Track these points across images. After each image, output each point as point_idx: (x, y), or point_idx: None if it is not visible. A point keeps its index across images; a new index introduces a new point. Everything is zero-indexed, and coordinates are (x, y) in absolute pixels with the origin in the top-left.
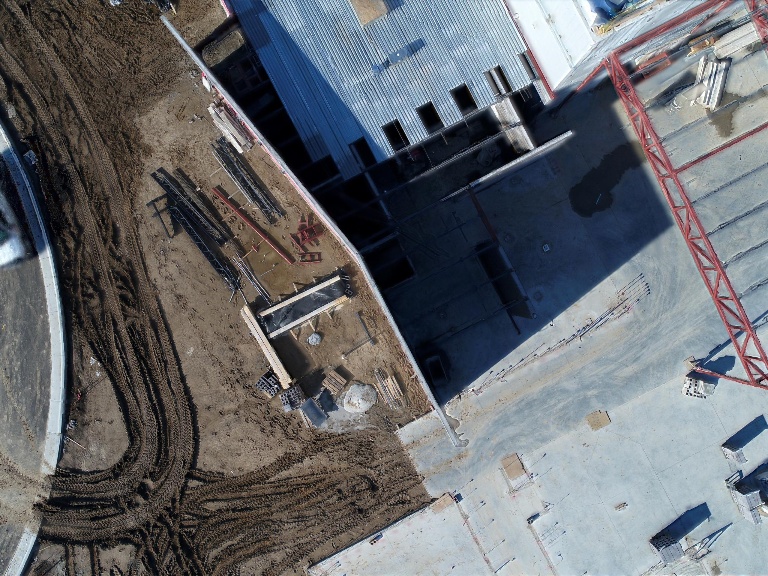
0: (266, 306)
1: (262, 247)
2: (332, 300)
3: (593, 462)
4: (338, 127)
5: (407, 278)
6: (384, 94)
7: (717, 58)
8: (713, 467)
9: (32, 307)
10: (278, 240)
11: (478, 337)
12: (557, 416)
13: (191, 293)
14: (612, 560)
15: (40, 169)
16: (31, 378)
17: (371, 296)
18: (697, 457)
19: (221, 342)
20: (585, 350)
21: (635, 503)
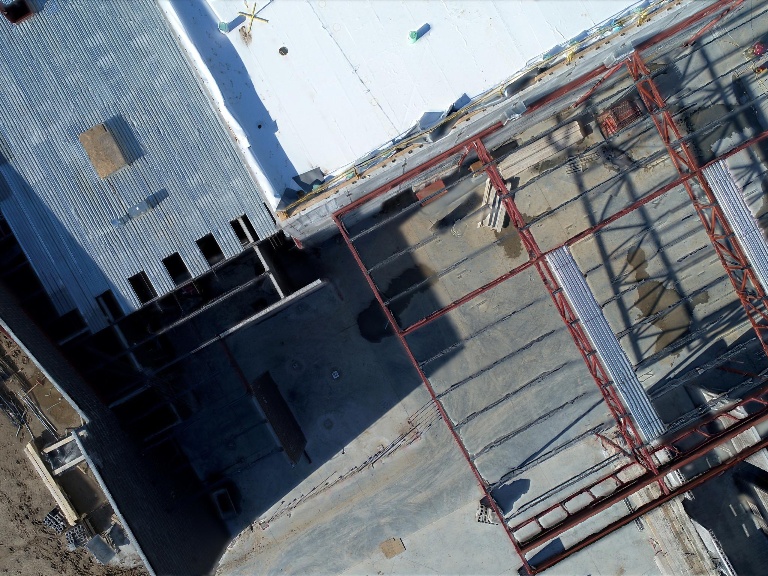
0: (53, 440)
1: None
2: None
3: None
4: (84, 280)
5: (171, 424)
6: (130, 246)
7: (503, 179)
8: None
9: None
10: None
11: (268, 467)
12: (351, 545)
13: None
14: None
15: None
16: None
17: None
18: None
19: (9, 478)
20: (378, 477)
21: None
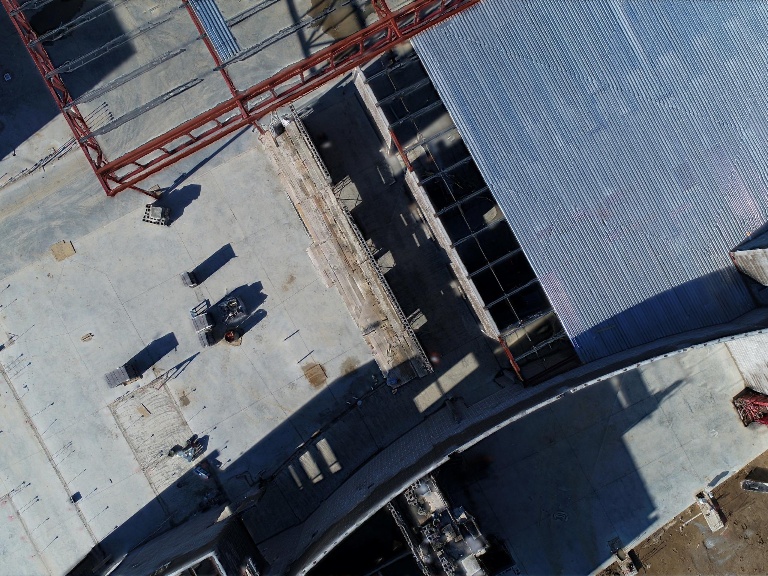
0: None
1: None
2: None
3: (58, 293)
4: None
5: None
6: None
7: None
8: (180, 296)
9: None
10: None
11: None
12: (21, 247)
13: None
14: (79, 391)
15: None
16: None
17: None
18: (164, 287)
19: None
20: (48, 180)
21: (101, 333)
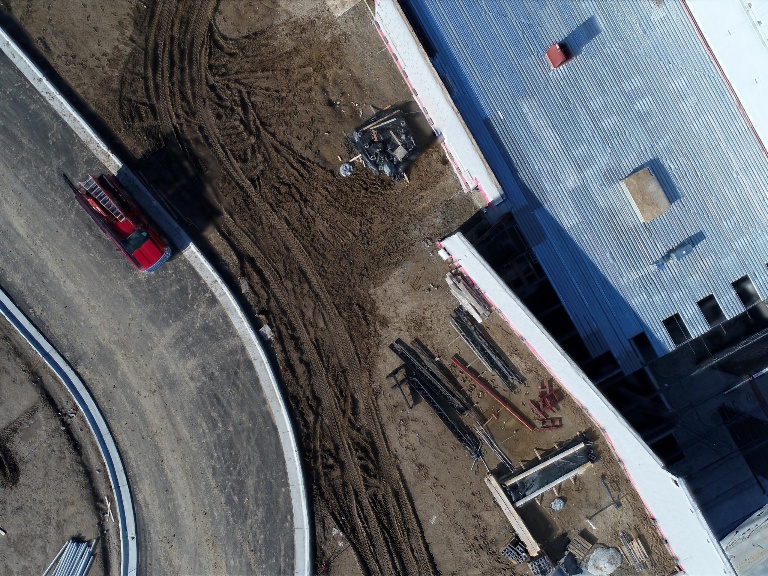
0: (508, 473)
1: (502, 414)
2: (577, 467)
3: None
4: (618, 323)
5: (677, 461)
6: (665, 288)
7: None
8: None
9: (273, 481)
10: (518, 406)
11: (723, 498)
12: None
13: (432, 462)
14: None
15: (276, 343)
16: (275, 551)
17: (613, 459)
18: None
19: (463, 509)
20: None
21: None
